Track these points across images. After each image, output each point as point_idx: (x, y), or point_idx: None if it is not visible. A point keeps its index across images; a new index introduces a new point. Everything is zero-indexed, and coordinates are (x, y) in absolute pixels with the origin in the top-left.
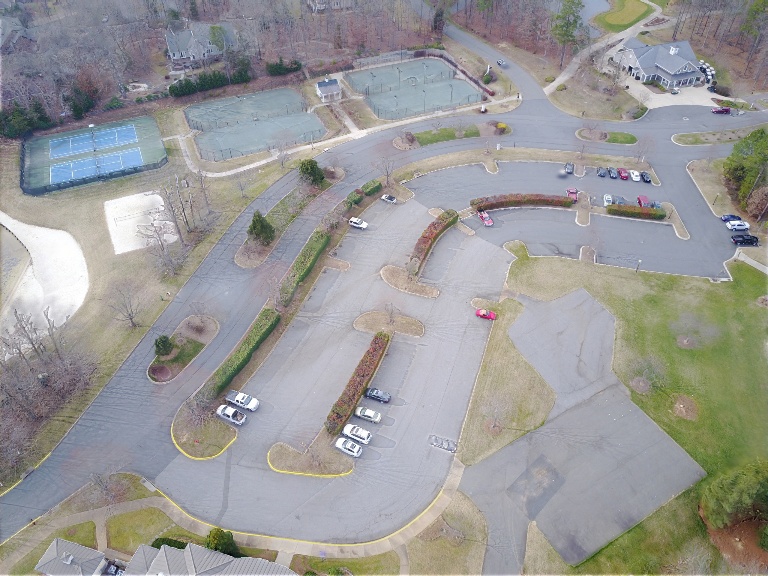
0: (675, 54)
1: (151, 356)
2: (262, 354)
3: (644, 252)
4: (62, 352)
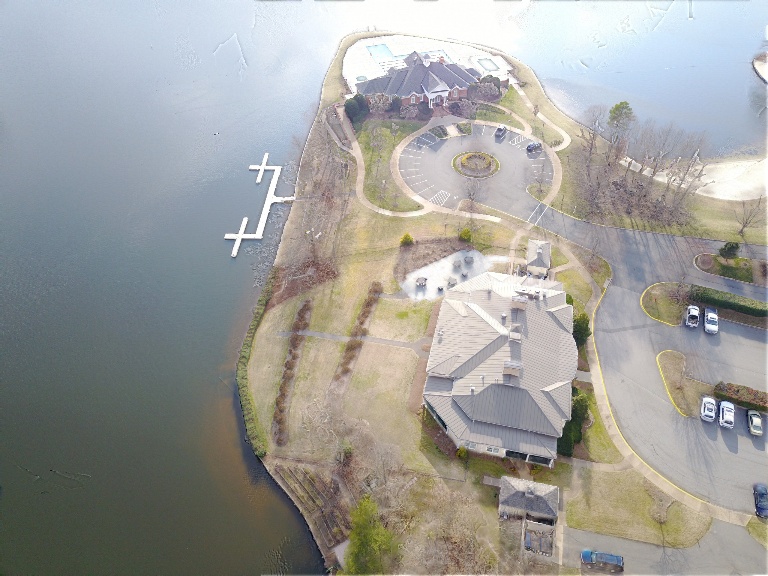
0: None
1: (717, 252)
2: None
3: None
4: (685, 198)
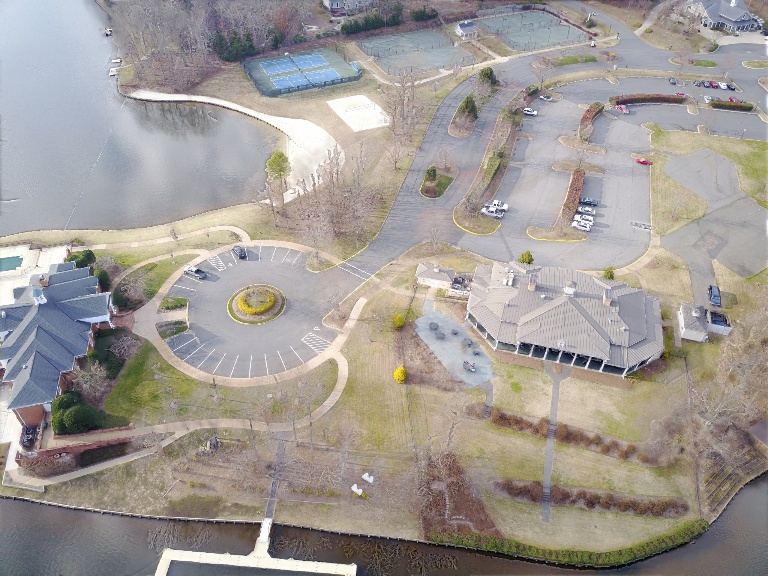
0: (735, 6)
1: (418, 185)
2: (497, 183)
3: (743, 129)
4: None
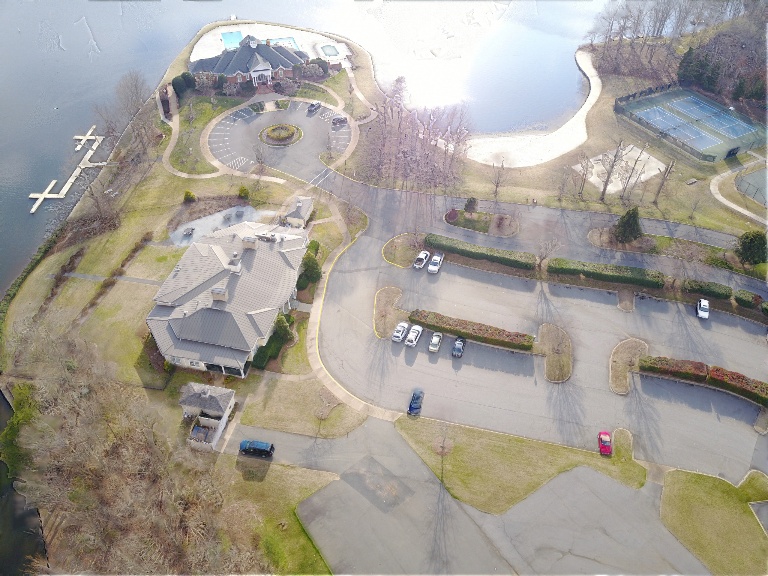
0: None
1: None
2: (487, 266)
3: None
4: (452, 163)
